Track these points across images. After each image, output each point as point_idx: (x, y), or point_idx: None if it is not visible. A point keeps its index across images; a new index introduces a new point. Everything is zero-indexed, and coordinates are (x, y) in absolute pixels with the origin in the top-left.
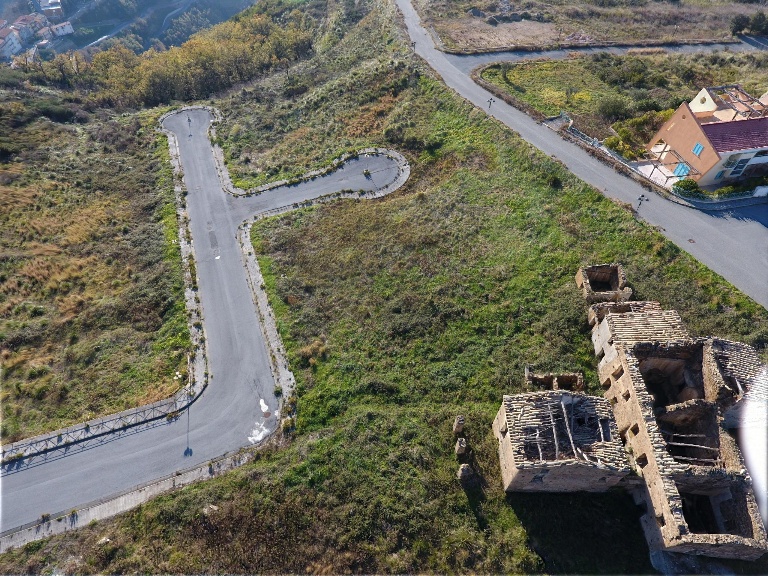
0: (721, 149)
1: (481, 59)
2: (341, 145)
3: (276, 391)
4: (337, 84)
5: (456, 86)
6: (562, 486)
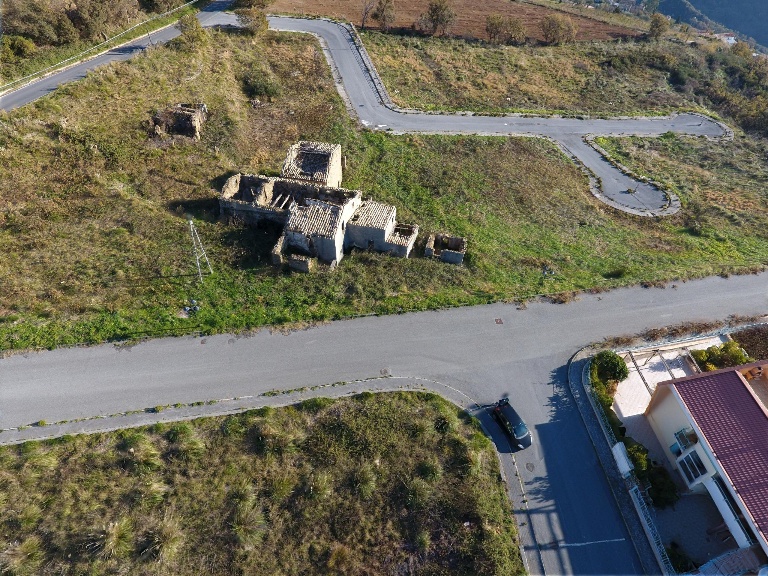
0: (685, 391)
1: None
2: None
3: None
4: None
5: None
6: None
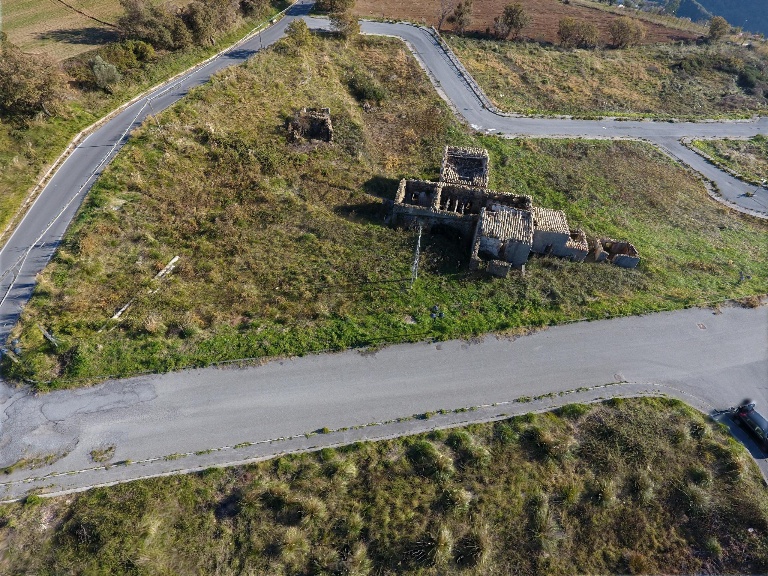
0: None
1: None
2: None
3: (500, 132)
4: None
5: None
6: None
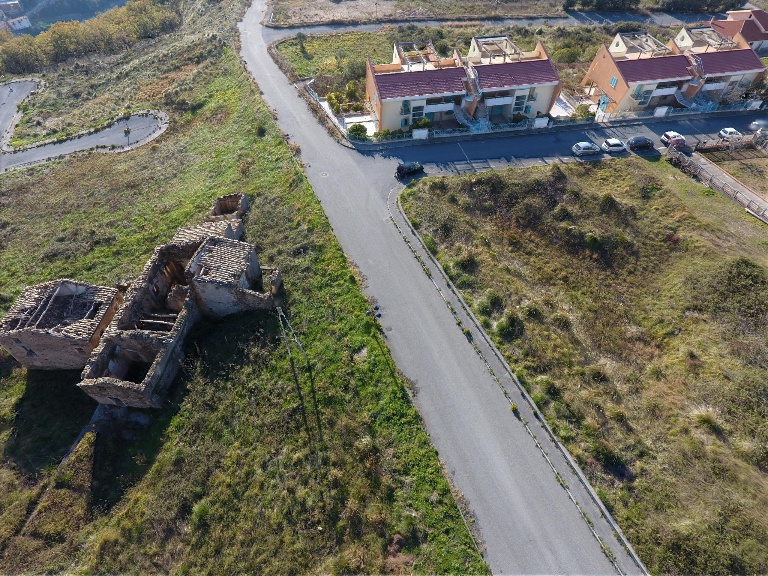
0: (386, 96)
1: (294, 32)
2: (124, 108)
3: None
4: (153, 56)
5: (247, 54)
6: (62, 361)
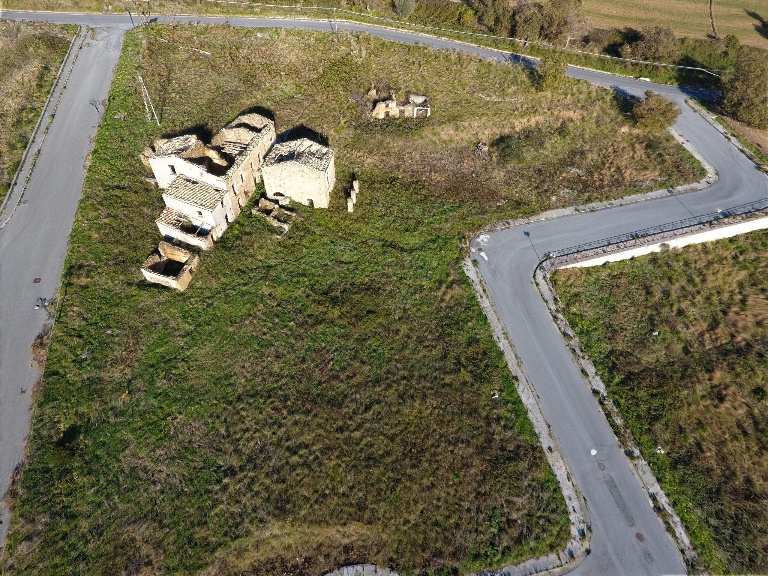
0: None
1: None
2: None
3: (477, 262)
4: None
5: None
6: None
